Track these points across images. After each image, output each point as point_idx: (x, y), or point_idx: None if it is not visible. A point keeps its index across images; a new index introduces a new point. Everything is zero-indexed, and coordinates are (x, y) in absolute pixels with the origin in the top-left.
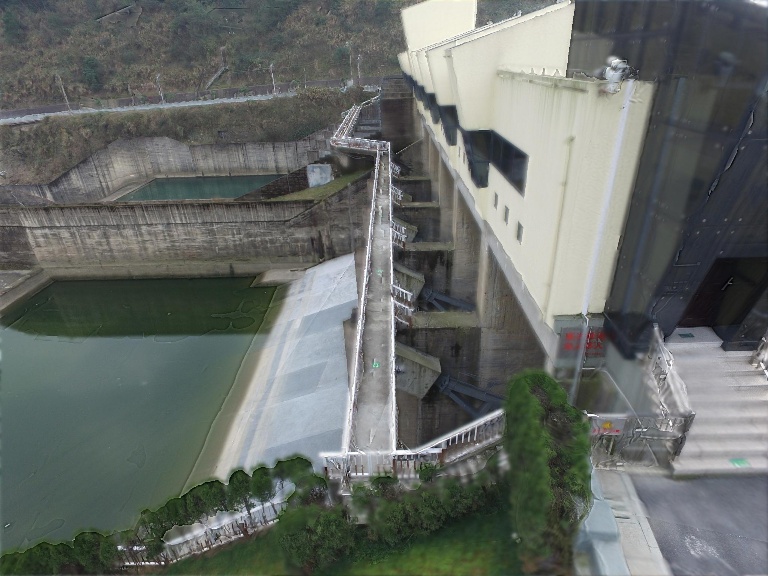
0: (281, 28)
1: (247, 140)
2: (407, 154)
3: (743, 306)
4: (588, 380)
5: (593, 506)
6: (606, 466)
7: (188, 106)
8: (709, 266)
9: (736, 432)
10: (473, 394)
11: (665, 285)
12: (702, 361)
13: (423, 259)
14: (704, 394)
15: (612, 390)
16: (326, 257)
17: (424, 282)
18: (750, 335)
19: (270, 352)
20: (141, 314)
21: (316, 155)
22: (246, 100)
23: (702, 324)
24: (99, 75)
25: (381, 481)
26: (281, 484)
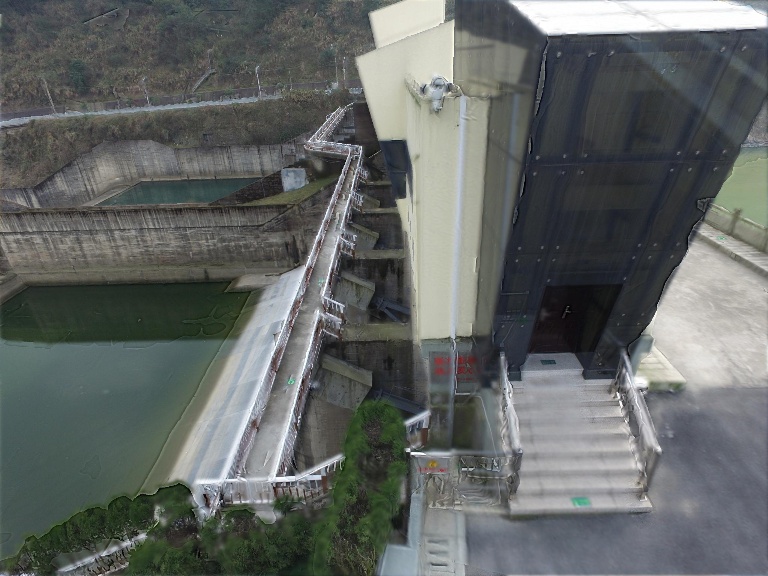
0: (268, 30)
1: (232, 143)
2: (379, 158)
3: (592, 334)
4: (463, 406)
5: (398, 555)
6: (443, 505)
7: (173, 109)
8: (541, 294)
9: (581, 468)
10: (407, 408)
11: (498, 314)
12: (560, 390)
13: (373, 267)
14: (556, 426)
15: (481, 417)
16: (301, 262)
17: (374, 291)
18: (606, 363)
19: (235, 359)
20: (117, 319)
21: (293, 159)
22: (231, 103)
23: (565, 350)
24: (86, 78)
25: (234, 515)
26: (160, 512)
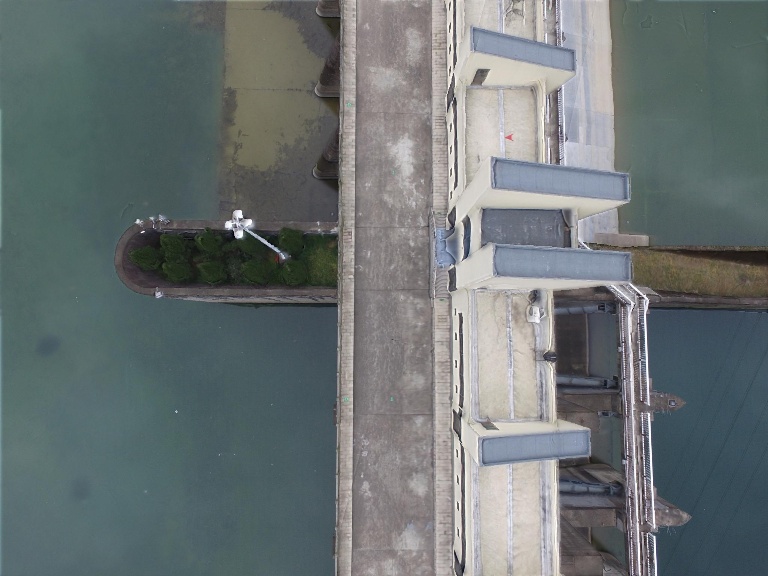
0: None
1: None
2: None
3: None
4: None
5: None
6: None
7: None
8: None
9: None
10: None
11: None
12: None
13: None
14: None
15: None
16: None
17: None
18: None
19: (595, 103)
20: None
21: None
22: None
23: None
24: None
25: None
26: None
